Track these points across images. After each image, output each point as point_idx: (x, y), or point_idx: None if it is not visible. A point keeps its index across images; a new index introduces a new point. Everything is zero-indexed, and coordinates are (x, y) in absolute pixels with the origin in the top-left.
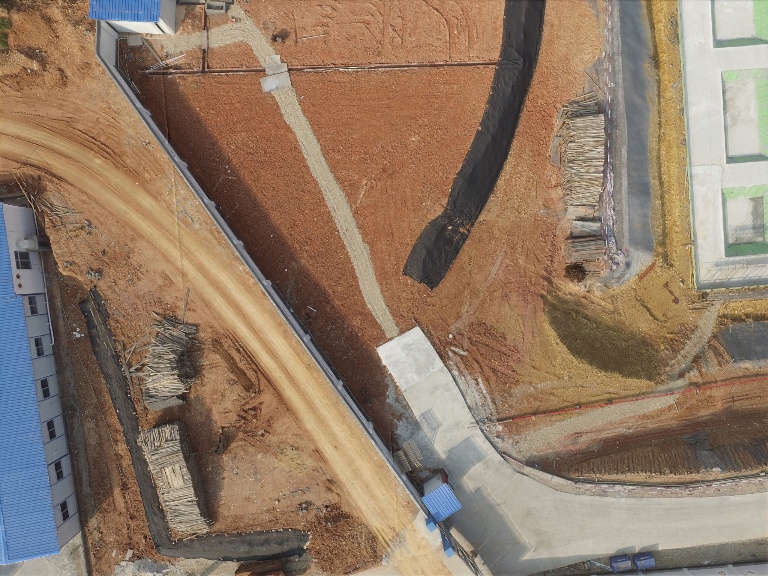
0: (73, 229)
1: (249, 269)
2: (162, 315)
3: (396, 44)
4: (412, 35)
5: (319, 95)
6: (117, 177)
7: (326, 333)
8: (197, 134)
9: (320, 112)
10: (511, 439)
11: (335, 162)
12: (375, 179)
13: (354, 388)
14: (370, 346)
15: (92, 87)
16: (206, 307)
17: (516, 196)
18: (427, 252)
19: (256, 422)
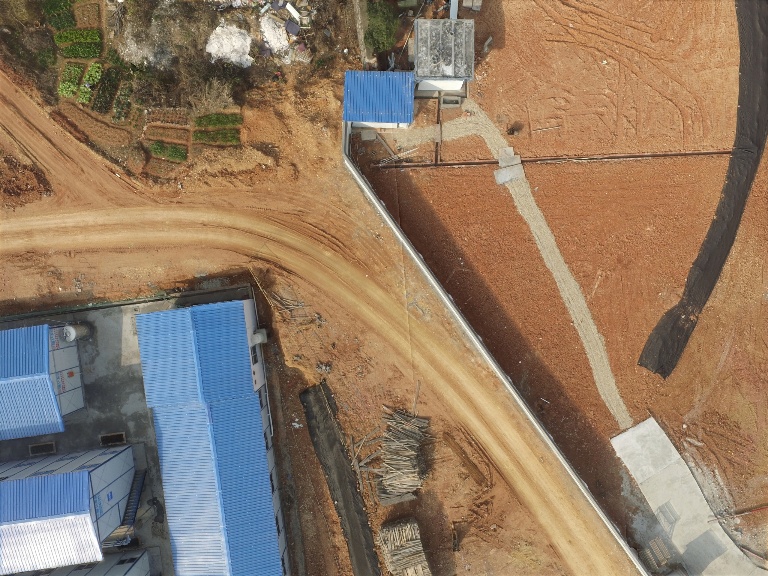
0: (303, 322)
1: (496, 366)
2: (392, 408)
3: (630, 135)
4: (646, 125)
5: (553, 186)
6: (347, 269)
7: (559, 425)
8: (430, 227)
9: (554, 203)
10: (749, 532)
11: (570, 253)
12: (610, 269)
13: (588, 481)
14: (604, 438)
15: (323, 181)
16: (438, 400)
17: (742, 281)
18: (663, 342)
19: (487, 516)
